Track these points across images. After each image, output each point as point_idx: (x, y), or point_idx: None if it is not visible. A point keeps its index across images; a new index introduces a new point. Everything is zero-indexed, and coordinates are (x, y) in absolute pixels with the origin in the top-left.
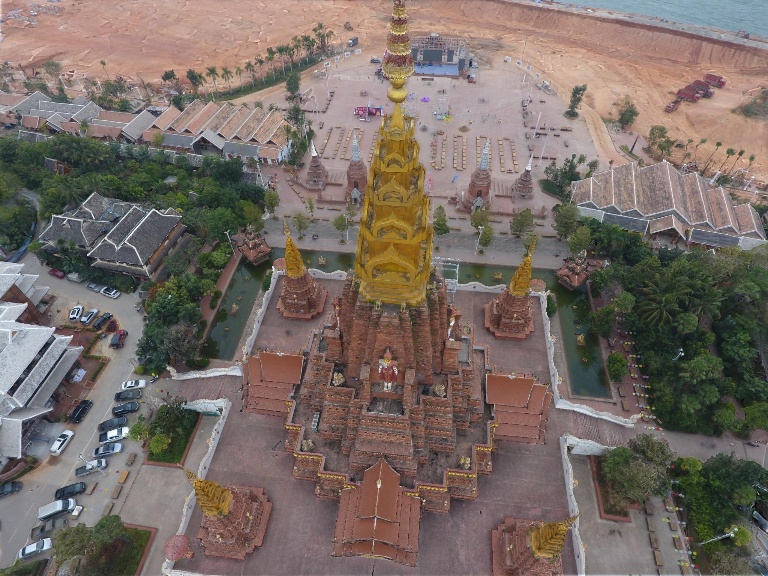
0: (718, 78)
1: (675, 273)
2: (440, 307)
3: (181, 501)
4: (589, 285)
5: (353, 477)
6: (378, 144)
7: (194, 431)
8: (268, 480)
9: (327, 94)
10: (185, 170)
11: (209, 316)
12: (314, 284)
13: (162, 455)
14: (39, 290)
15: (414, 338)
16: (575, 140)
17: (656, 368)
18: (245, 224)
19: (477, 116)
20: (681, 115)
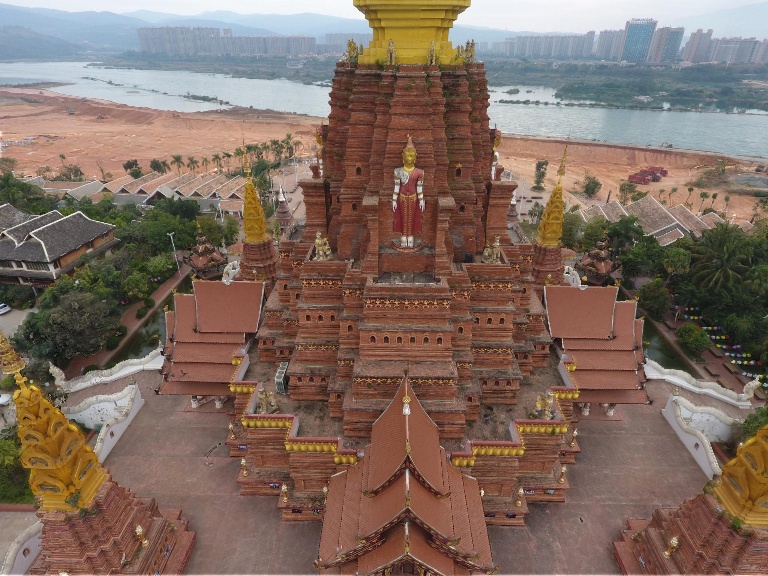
0: (660, 168)
1: None
2: None
3: None
4: None
5: None
6: None
7: None
8: (191, 500)
9: (295, 181)
10: None
11: (132, 326)
12: None
13: (3, 489)
14: None
15: (447, 144)
16: None
17: (747, 330)
18: (196, 244)
19: None
20: None
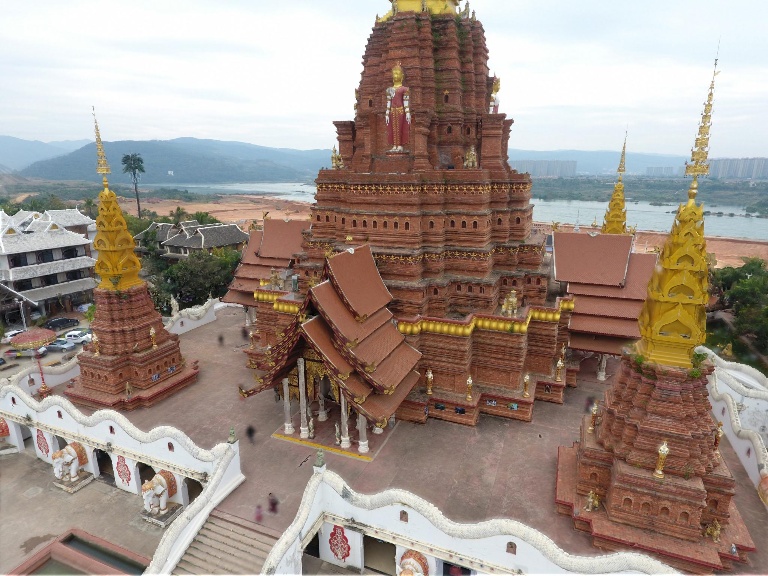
0: None
1: None
2: (476, 51)
3: None
4: (730, 322)
5: None
6: None
7: None
8: (210, 364)
9: None
10: None
11: None
12: None
13: None
14: None
15: (437, 75)
16: None
17: None
18: None
19: None
20: None
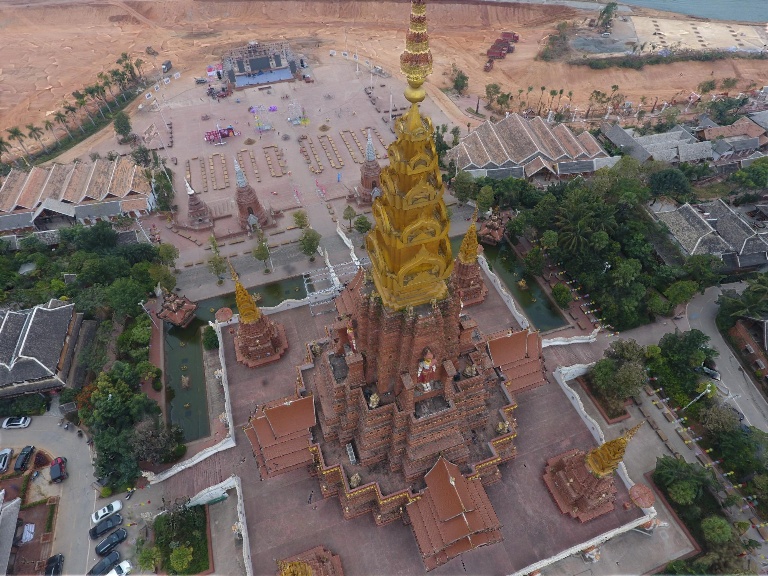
0: (512, 34)
1: (576, 202)
2: None
3: None
4: (506, 236)
5: (413, 489)
6: (396, 149)
7: (207, 527)
8: (320, 535)
9: (165, 127)
10: (40, 252)
11: (159, 400)
12: (271, 322)
13: (185, 569)
14: None
15: None
16: (427, 114)
17: (593, 285)
18: (151, 288)
19: (330, 113)
20: (498, 72)
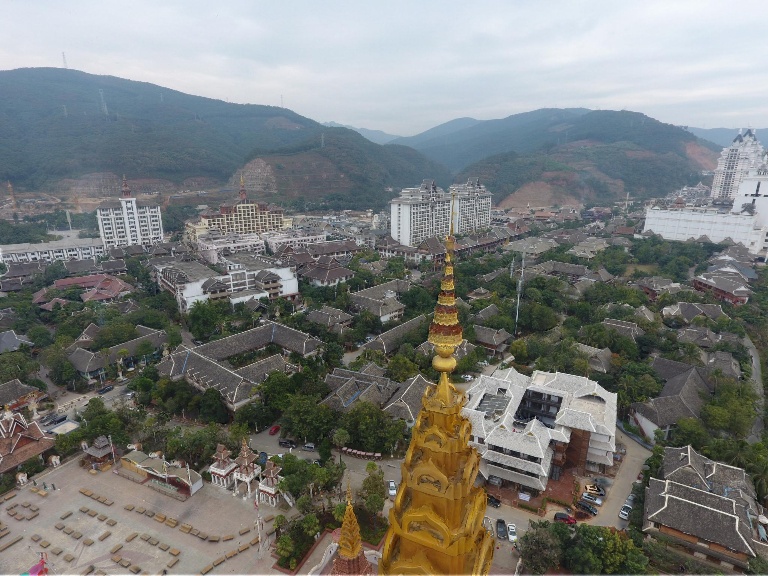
0: None
1: None
2: None
3: None
4: None
5: None
6: None
7: None
8: None
9: None
10: None
11: None
12: None
13: None
14: (606, 459)
15: None
16: None
17: None
18: None
19: None
20: None
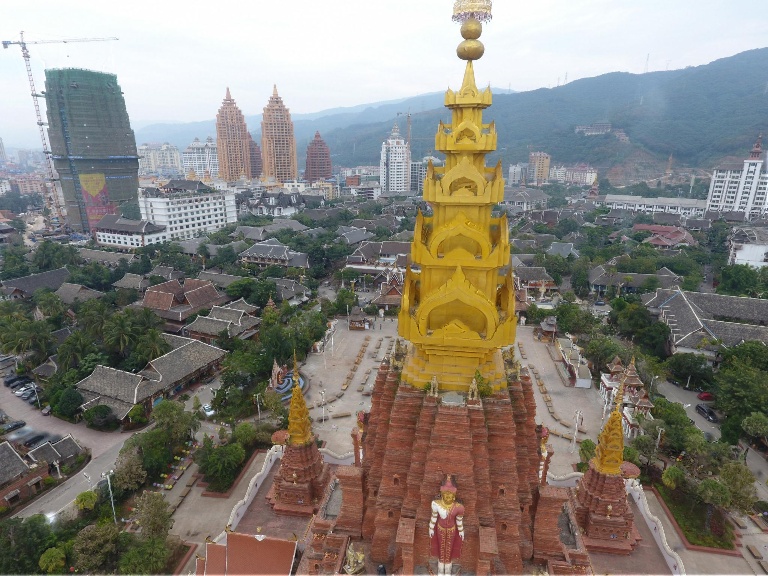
0: None
1: None
2: None
3: (688, 575)
4: None
5: None
6: None
7: None
8: None
9: None
10: None
11: None
12: None
13: None
14: None
15: None
16: None
17: None
18: None
19: None
20: None
